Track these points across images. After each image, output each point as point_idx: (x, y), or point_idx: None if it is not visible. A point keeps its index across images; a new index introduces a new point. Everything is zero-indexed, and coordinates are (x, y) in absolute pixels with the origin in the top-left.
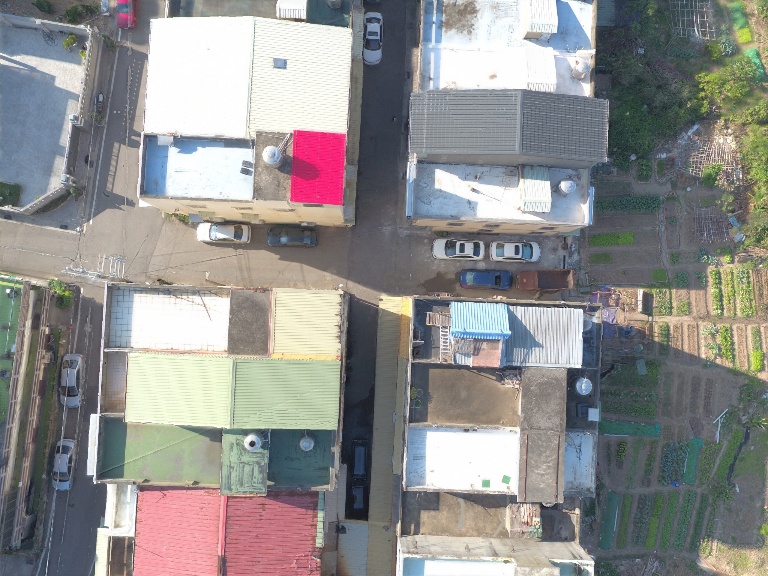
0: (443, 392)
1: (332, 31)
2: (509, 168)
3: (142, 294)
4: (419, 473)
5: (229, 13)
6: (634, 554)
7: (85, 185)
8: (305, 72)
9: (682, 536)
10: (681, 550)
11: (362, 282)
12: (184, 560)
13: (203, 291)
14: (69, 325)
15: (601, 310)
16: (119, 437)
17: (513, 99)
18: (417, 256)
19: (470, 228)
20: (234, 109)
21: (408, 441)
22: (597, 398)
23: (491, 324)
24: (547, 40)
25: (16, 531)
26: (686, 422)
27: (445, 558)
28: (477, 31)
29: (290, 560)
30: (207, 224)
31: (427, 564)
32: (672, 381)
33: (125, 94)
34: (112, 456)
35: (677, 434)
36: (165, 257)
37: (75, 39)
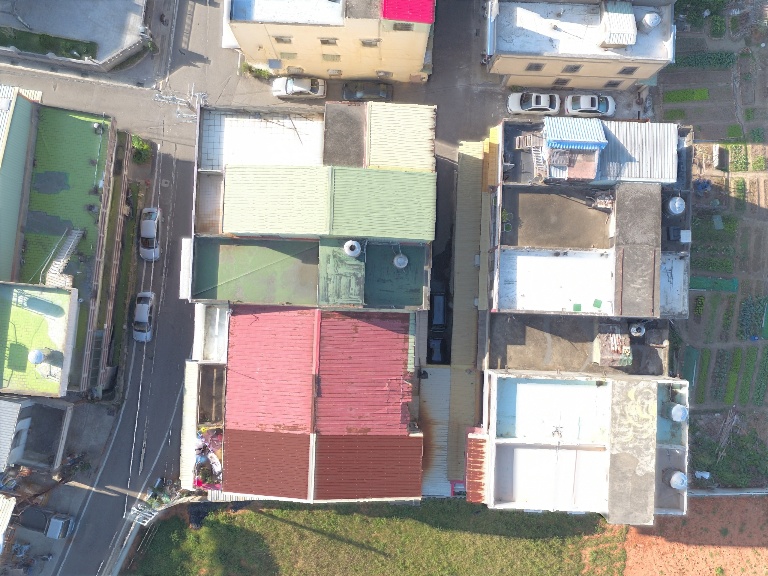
0: (533, 217)
1: None
2: (591, 6)
3: (233, 118)
4: (510, 297)
5: None
6: (713, 409)
7: (160, 44)
8: None
9: (761, 390)
10: (760, 404)
11: (437, 137)
12: (278, 381)
13: (294, 115)
14: (147, 181)
15: (692, 132)
16: (212, 260)
17: None
18: None
19: (548, 76)
20: None
21: (499, 265)
22: (689, 220)
23: (587, 135)
24: None
25: (101, 373)
26: (764, 276)
27: (539, 378)
28: None
29: (382, 383)
30: (283, 78)
31: (519, 387)
32: (749, 236)
33: None
34: (205, 278)
35: (755, 289)
36: (249, 96)
37: None
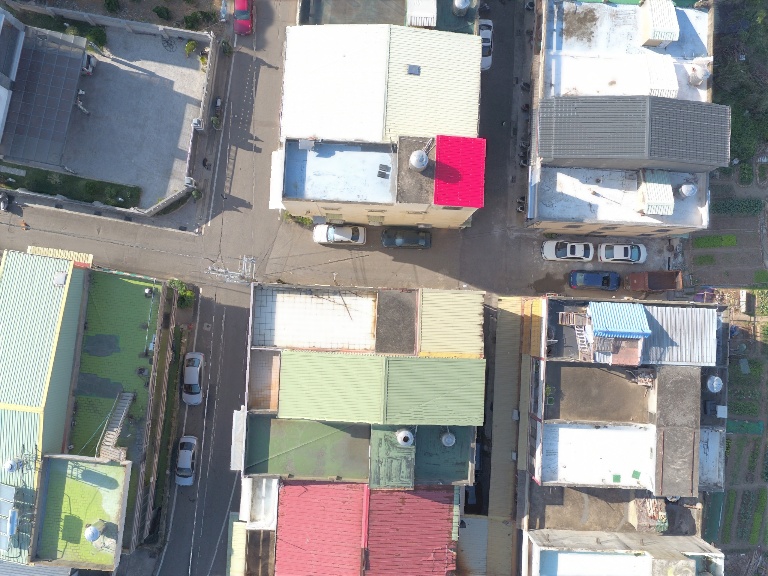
0: (575, 390)
1: (463, 38)
2: (628, 172)
3: (285, 294)
4: (552, 468)
5: (357, 20)
6: (738, 549)
7: (203, 187)
8: (438, 78)
9: None
10: None
11: (473, 283)
12: (327, 553)
13: (344, 291)
14: (189, 324)
15: (729, 310)
16: (263, 433)
17: (641, 105)
18: (527, 257)
19: (584, 230)
20: (371, 114)
21: None
22: (725, 396)
23: (631, 323)
24: (664, 47)
25: (147, 525)
26: None
27: (580, 551)
28: (596, 38)
29: (428, 553)
30: (324, 226)
31: (560, 557)
32: None
33: (241, 99)
34: (256, 451)
35: None
36: (295, 258)
37: (195, 45)
